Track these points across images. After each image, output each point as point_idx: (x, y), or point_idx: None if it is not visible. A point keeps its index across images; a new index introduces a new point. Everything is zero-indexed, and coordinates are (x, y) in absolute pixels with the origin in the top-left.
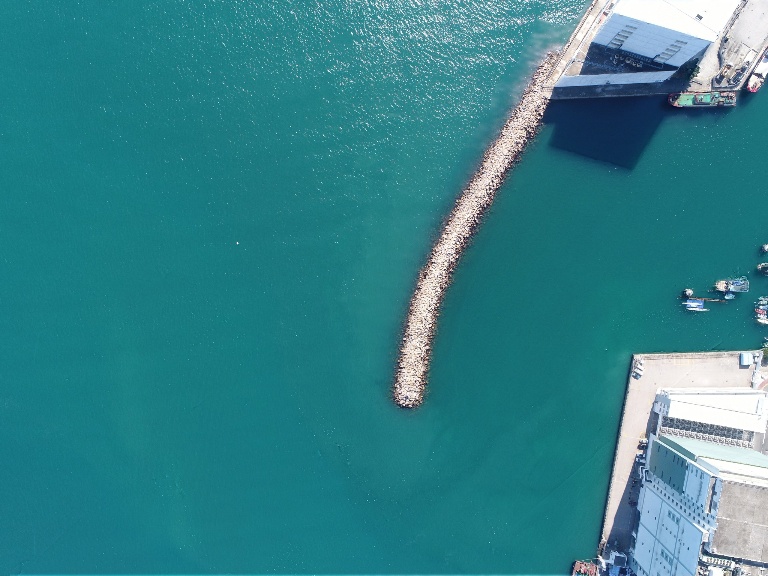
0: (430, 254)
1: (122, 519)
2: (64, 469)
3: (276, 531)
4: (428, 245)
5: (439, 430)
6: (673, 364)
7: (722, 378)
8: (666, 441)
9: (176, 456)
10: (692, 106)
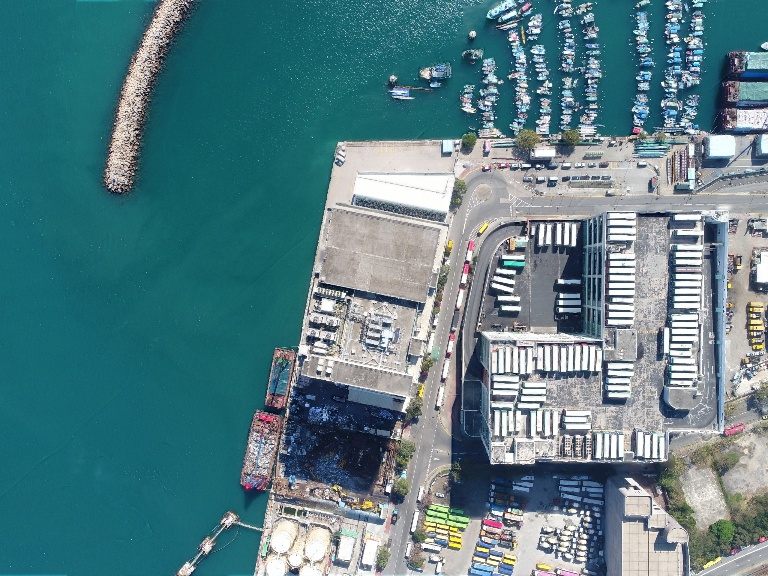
0: (142, 39)
1: None
2: None
3: None
4: (141, 30)
5: (148, 216)
6: (376, 151)
7: (424, 166)
8: None
9: None
10: None
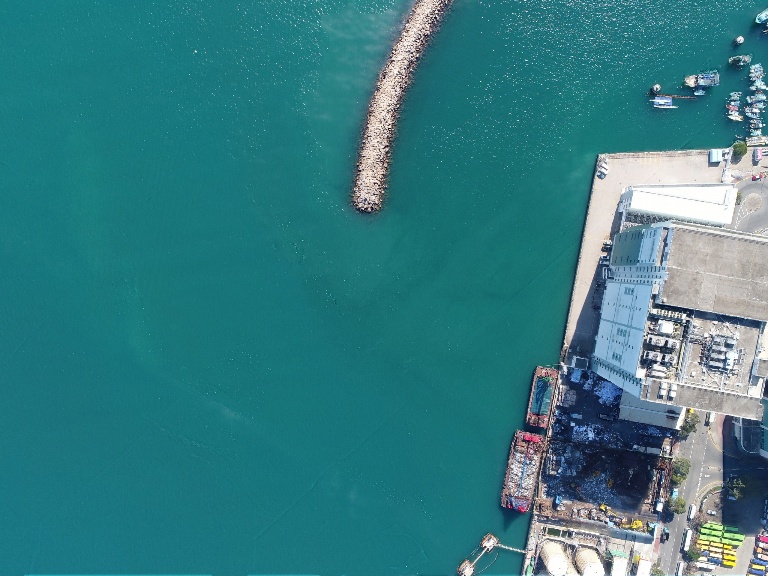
0: (390, 54)
1: (83, 326)
2: (26, 277)
3: (230, 323)
4: (388, 45)
5: (399, 235)
6: (639, 163)
7: (690, 177)
8: (627, 230)
9: (133, 256)
10: None
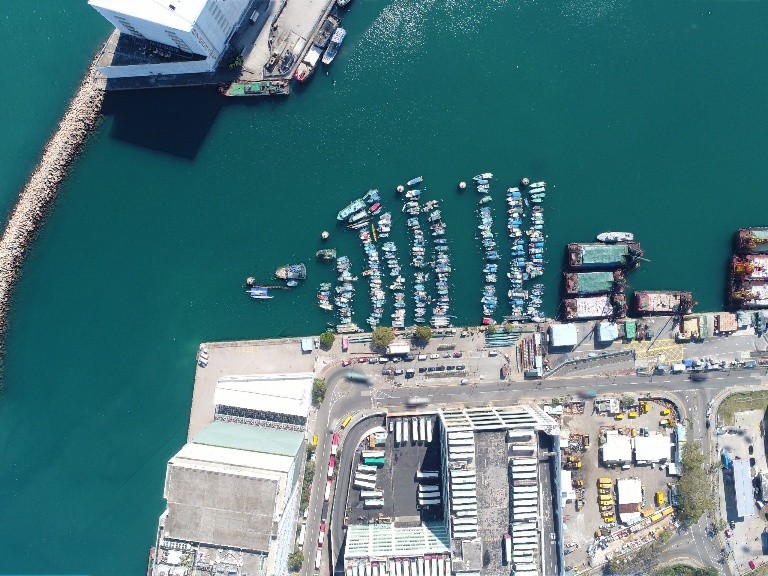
0: None
1: None
2: None
3: None
4: None
5: (14, 424)
6: (238, 352)
7: (286, 364)
8: None
9: None
10: (245, 95)
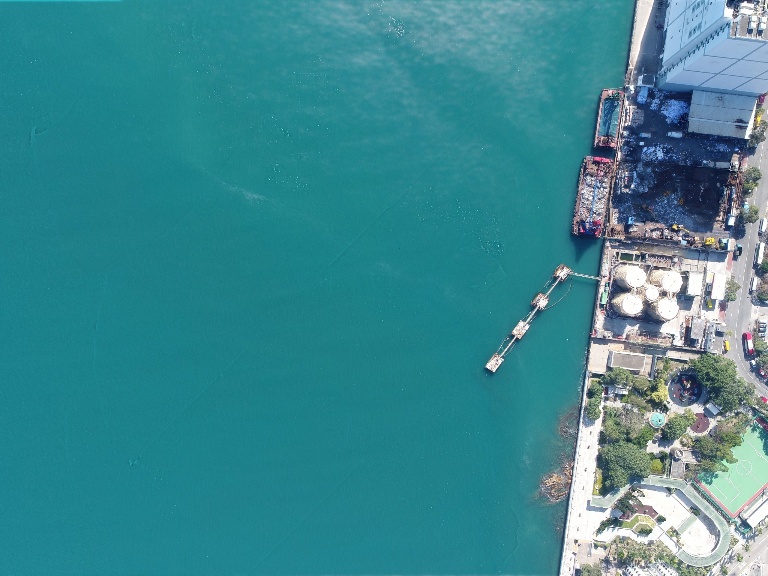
0: None
1: (139, 77)
2: (78, 32)
3: (297, 43)
4: None
5: None
6: None
7: None
8: None
9: None
10: None
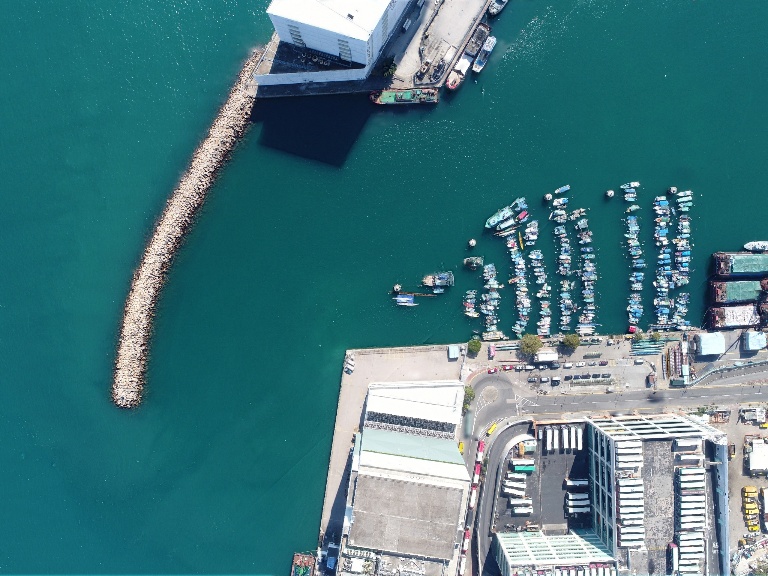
0: (143, 255)
1: None
2: None
3: None
4: (142, 246)
5: (159, 429)
6: (384, 359)
7: (432, 371)
8: None
9: None
10: (395, 103)
